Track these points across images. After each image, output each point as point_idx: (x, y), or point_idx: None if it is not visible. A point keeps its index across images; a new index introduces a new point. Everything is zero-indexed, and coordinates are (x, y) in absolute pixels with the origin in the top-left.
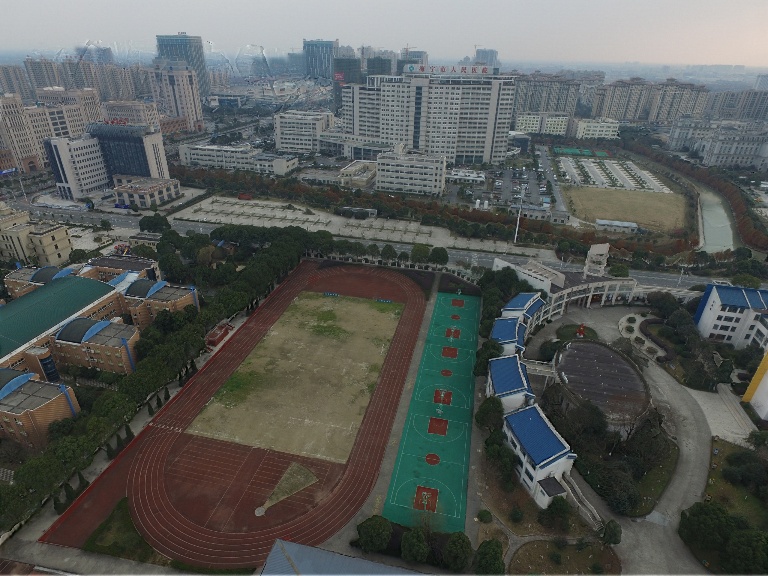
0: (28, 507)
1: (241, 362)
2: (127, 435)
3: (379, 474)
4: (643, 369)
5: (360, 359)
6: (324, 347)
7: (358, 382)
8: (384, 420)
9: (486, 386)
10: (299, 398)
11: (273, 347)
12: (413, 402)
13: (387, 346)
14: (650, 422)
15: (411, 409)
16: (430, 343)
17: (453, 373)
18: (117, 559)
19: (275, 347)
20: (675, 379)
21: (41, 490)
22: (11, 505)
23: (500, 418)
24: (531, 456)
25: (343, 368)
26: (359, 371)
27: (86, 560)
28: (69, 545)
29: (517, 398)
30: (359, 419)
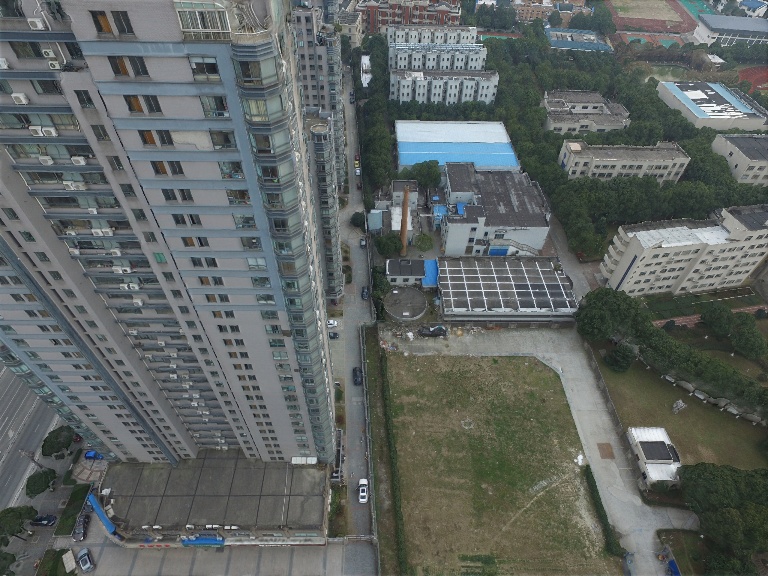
0: None
1: (612, 4)
2: None
3: (697, 22)
4: None
5: (658, 3)
6: (639, 1)
7: (665, 8)
8: None
9: (716, 8)
10: None
11: (618, 1)
12: None
13: (665, 1)
14: None
15: None
16: (682, 0)
17: (700, 6)
18: None
19: (619, 1)
20: None
21: None
22: None
23: (736, 5)
24: (754, 8)
25: (655, 5)
26: (662, 6)
27: None
28: (622, 30)
29: (740, 0)
30: (677, 14)
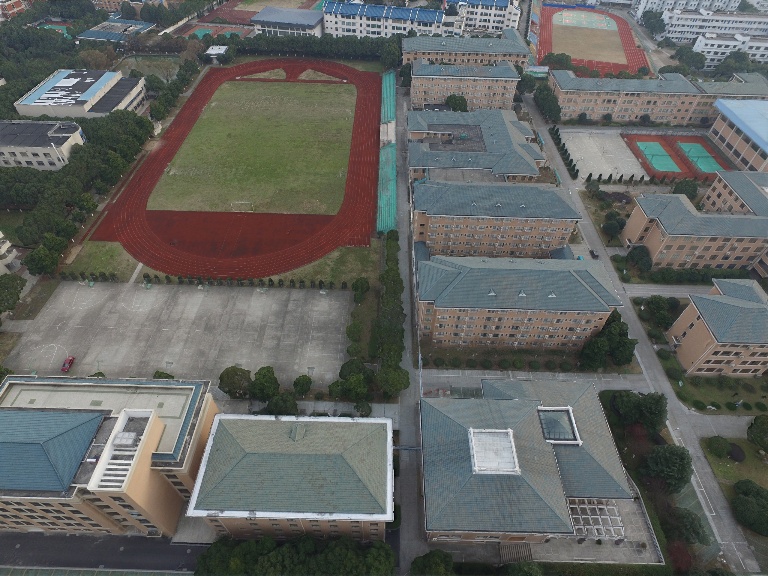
0: (192, 9)
1: None
2: (212, 8)
3: None
4: (417, 0)
5: None
6: None
7: (297, 1)
8: (306, 8)
9: None
10: (274, 4)
11: None
12: (318, 5)
13: None
14: (398, 1)
15: (317, 6)
16: None
17: (337, 0)
18: (221, 24)
19: None
20: (428, 2)
21: (193, 8)
22: (188, 6)
23: None
24: (348, 1)
25: None
26: None
27: (212, 24)
28: (206, 22)
29: None
30: None
